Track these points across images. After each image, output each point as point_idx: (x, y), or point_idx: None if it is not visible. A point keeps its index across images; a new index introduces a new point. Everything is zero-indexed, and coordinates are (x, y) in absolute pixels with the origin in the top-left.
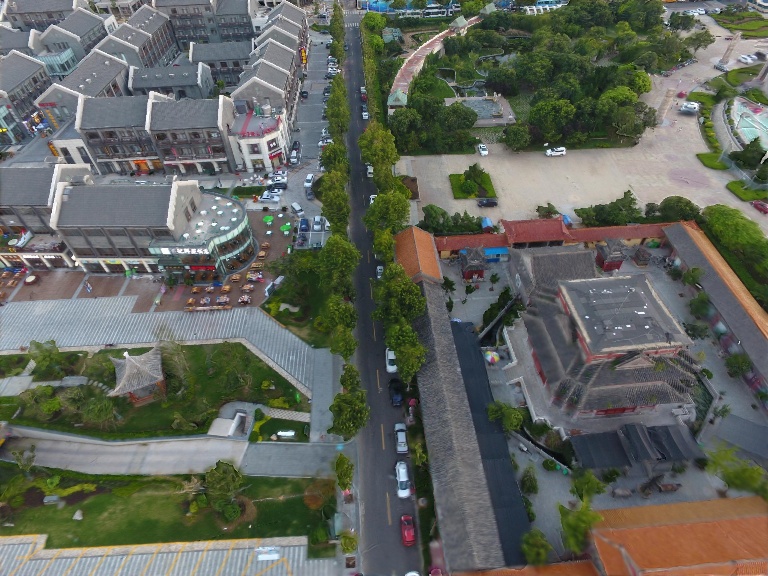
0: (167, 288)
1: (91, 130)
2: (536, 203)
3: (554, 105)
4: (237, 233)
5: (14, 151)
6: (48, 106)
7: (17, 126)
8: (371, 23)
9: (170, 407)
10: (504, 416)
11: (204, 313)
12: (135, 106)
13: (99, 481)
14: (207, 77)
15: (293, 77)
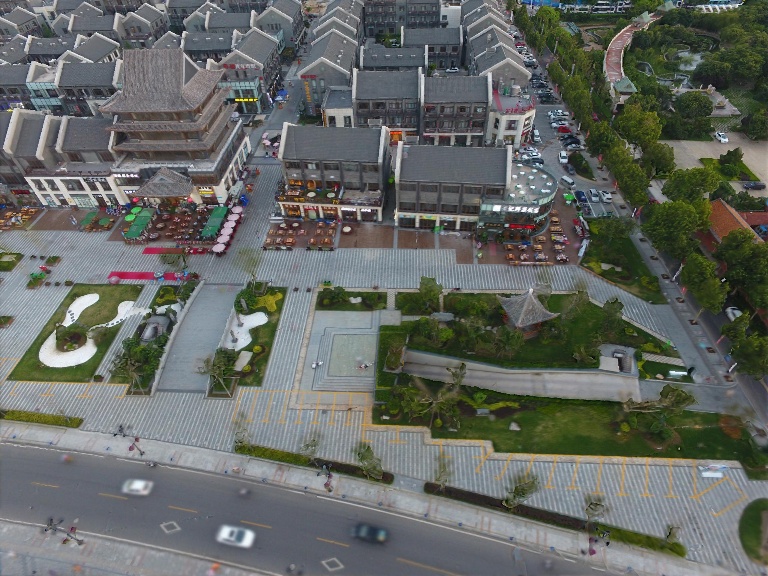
0: None
1: (364, 100)
2: None
3: None
4: (553, 197)
5: (262, 119)
6: (308, 78)
7: (261, 97)
8: None
9: (549, 344)
10: None
11: (528, 267)
12: (405, 80)
13: (521, 400)
14: None
15: None
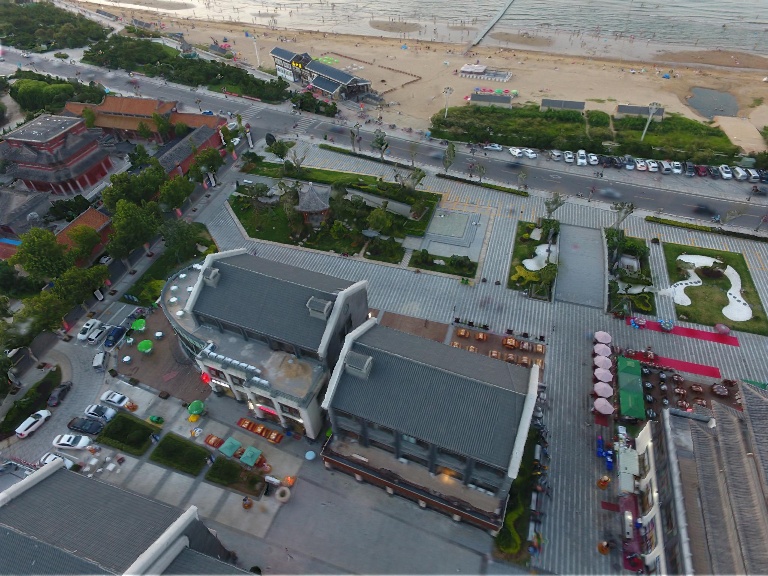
0: None
1: None
2: None
3: None
4: None
5: None
6: None
7: None
8: None
9: None
10: (143, 156)
11: None
12: None
13: None
14: None
15: None
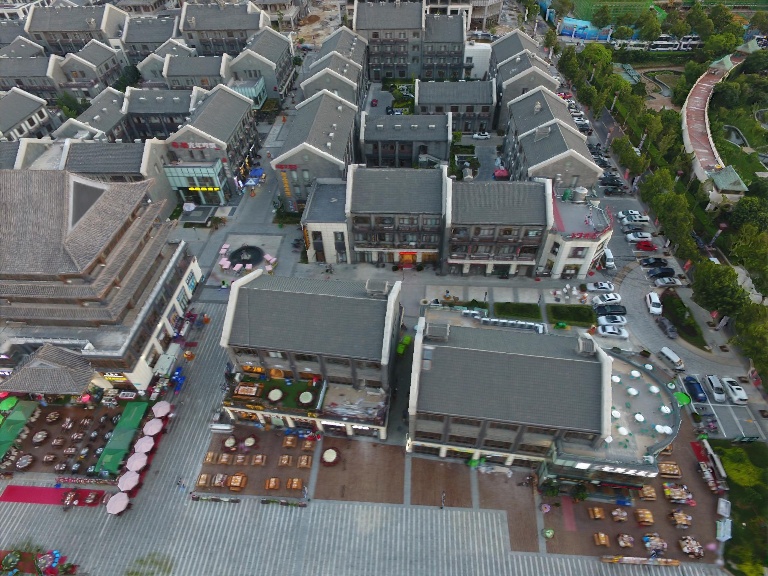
0: (545, 500)
1: (363, 214)
2: None
3: None
4: None
5: (225, 216)
6: (286, 168)
7: (226, 182)
8: (597, 57)
9: None
10: None
11: (634, 568)
12: (422, 185)
13: None
14: None
15: None
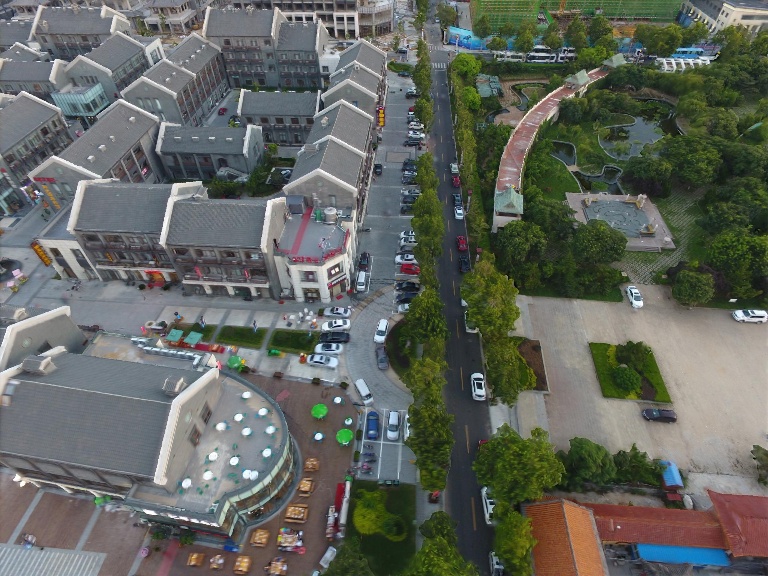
0: (152, 543)
1: (89, 232)
2: (738, 423)
3: (752, 244)
4: (269, 479)
5: (5, 227)
6: (45, 181)
7: (14, 192)
8: (463, 68)
9: None
10: None
11: None
12: (151, 203)
13: None
14: (256, 141)
15: (367, 154)
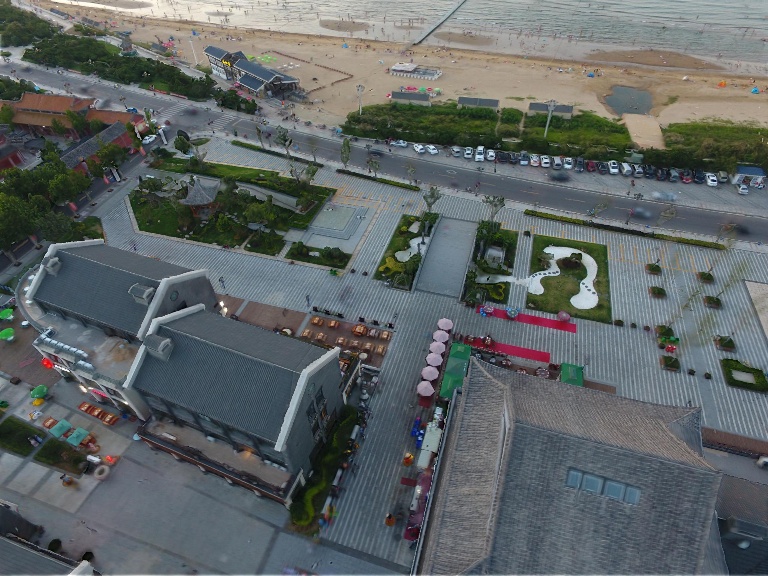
0: None
1: None
2: None
3: None
4: None
5: None
6: None
7: None
8: None
9: None
10: (52, 151)
11: None
12: None
13: None
14: None
15: None
